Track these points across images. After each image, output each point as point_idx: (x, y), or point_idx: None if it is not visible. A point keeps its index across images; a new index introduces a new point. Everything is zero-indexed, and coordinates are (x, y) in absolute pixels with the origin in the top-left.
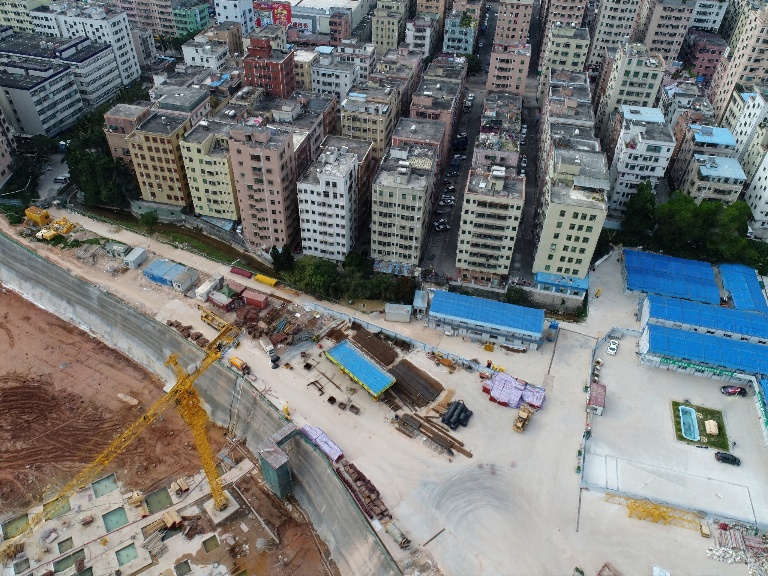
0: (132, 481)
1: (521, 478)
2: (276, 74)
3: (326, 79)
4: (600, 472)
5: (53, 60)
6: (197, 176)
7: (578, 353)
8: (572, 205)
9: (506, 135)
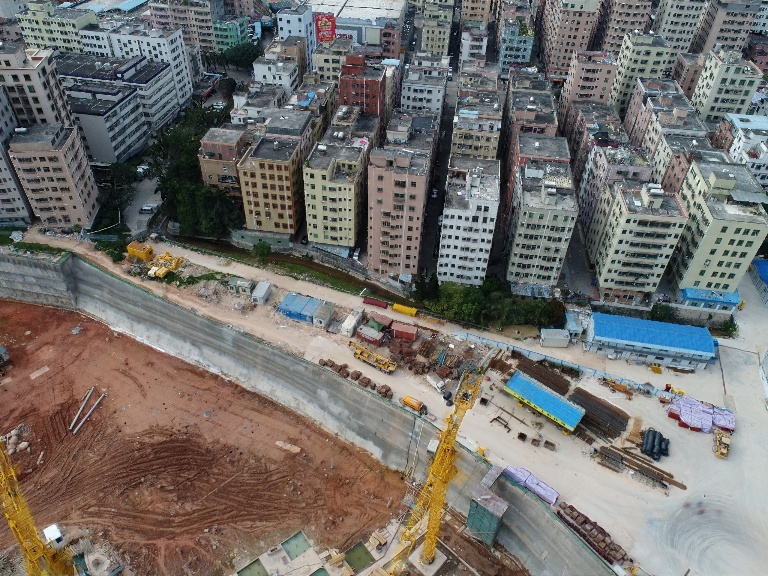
0: (323, 538)
1: (743, 508)
2: (374, 92)
3: (417, 95)
4: None
5: (114, 82)
6: (317, 203)
7: (746, 370)
8: (736, 221)
9: (631, 149)
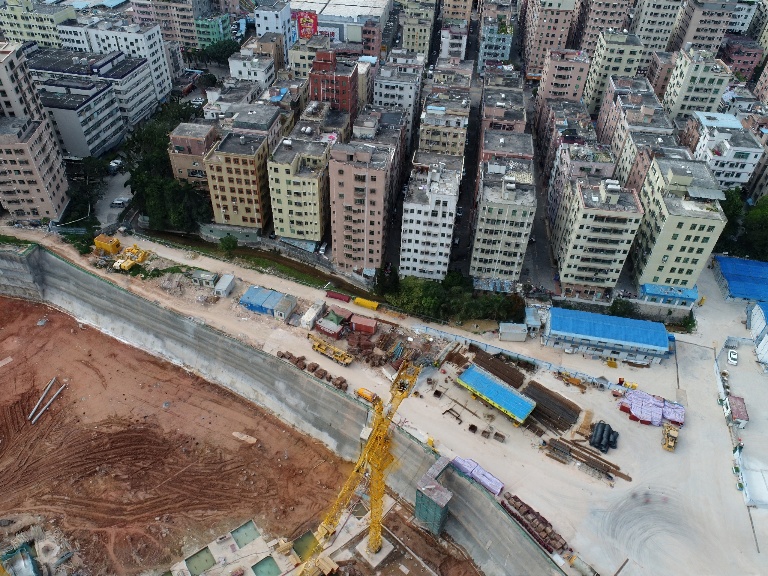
0: (273, 527)
1: (687, 499)
2: (344, 88)
3: (389, 91)
4: (761, 488)
5: (90, 77)
6: (282, 197)
7: (701, 365)
8: (691, 217)
9: (595, 146)
